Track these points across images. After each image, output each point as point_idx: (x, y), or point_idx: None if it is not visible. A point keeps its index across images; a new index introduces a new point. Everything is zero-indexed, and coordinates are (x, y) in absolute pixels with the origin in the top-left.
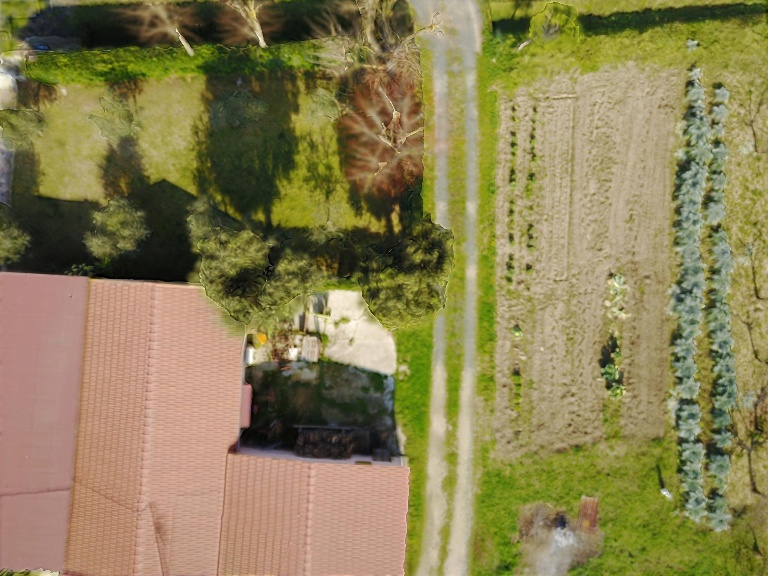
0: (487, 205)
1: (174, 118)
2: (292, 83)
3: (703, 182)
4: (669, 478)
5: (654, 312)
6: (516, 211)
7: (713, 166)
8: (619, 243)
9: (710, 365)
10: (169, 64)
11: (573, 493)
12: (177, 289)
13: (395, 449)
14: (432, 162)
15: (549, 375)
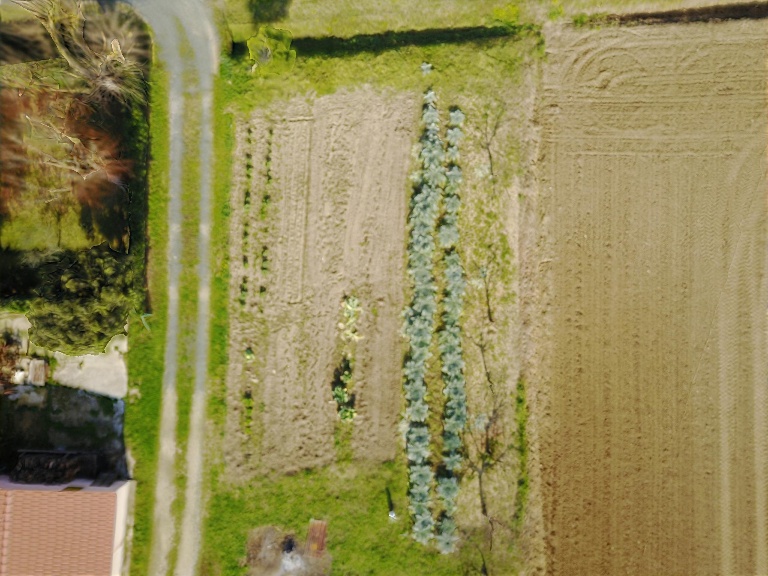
0: (221, 227)
1: None
2: (25, 104)
3: (434, 205)
4: (399, 501)
5: (387, 335)
6: (251, 233)
7: (447, 189)
8: (353, 266)
9: (442, 387)
10: None
11: (301, 516)
12: None
13: (124, 473)
14: (166, 184)
15: (281, 398)
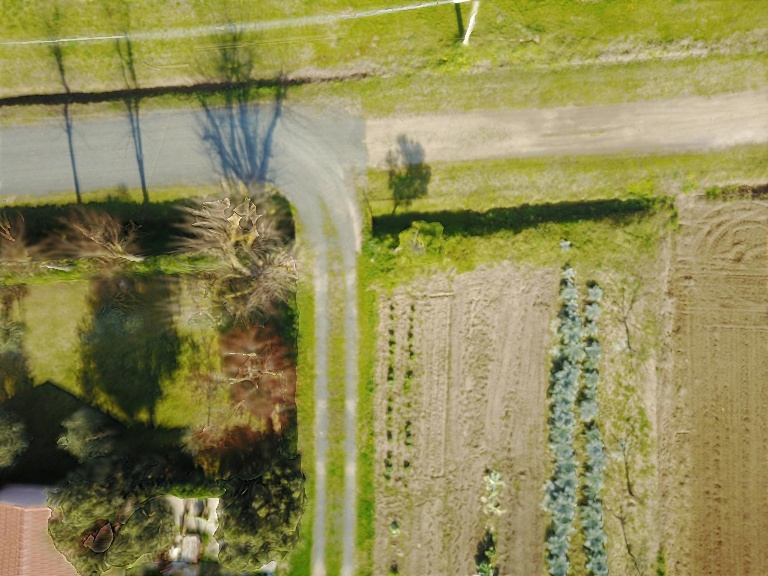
0: (365, 403)
1: (57, 320)
2: (174, 284)
3: (575, 382)
4: None
5: (529, 508)
6: (394, 408)
7: (586, 364)
8: (495, 440)
9: (583, 561)
10: (46, 277)
11: None
12: (47, 511)
13: None
14: (311, 361)
15: (426, 572)
